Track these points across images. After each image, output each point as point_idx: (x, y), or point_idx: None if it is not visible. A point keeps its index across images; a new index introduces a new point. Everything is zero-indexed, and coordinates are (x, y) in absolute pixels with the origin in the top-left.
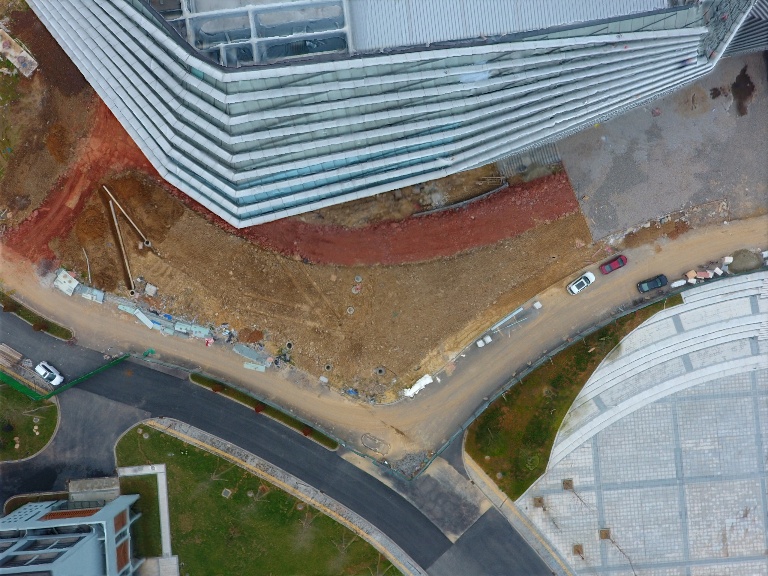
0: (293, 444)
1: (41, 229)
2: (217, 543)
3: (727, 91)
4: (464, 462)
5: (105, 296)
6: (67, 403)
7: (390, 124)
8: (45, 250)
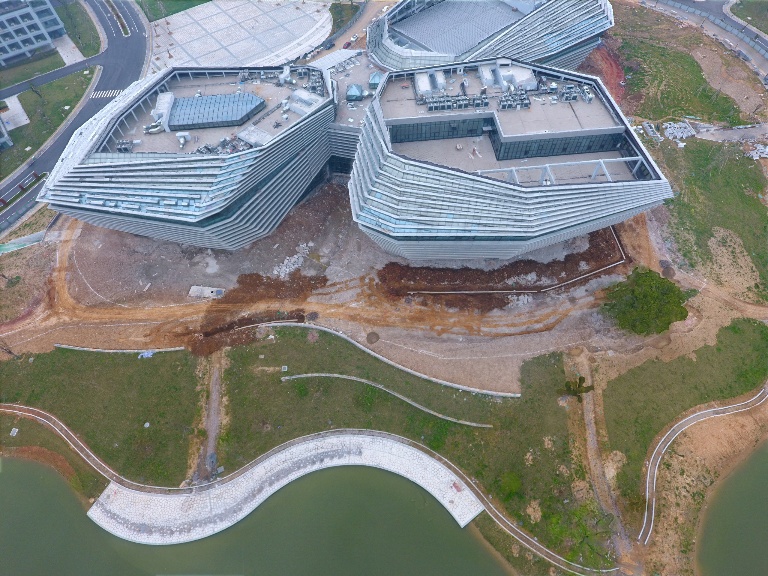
0: None
1: None
2: None
3: None
4: (356, 3)
5: None
6: None
7: None
8: None
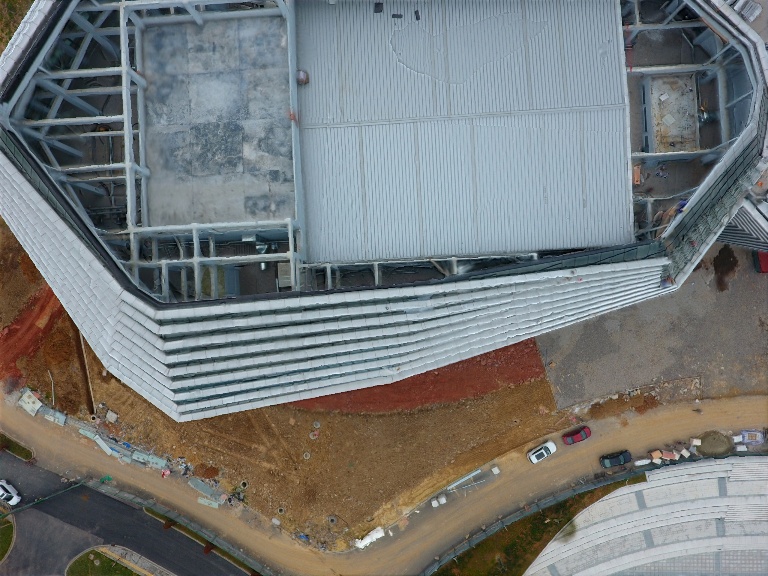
0: None
1: (10, 347)
2: None
3: (709, 264)
4: None
5: (67, 419)
6: (23, 522)
7: (332, 343)
8: (12, 368)
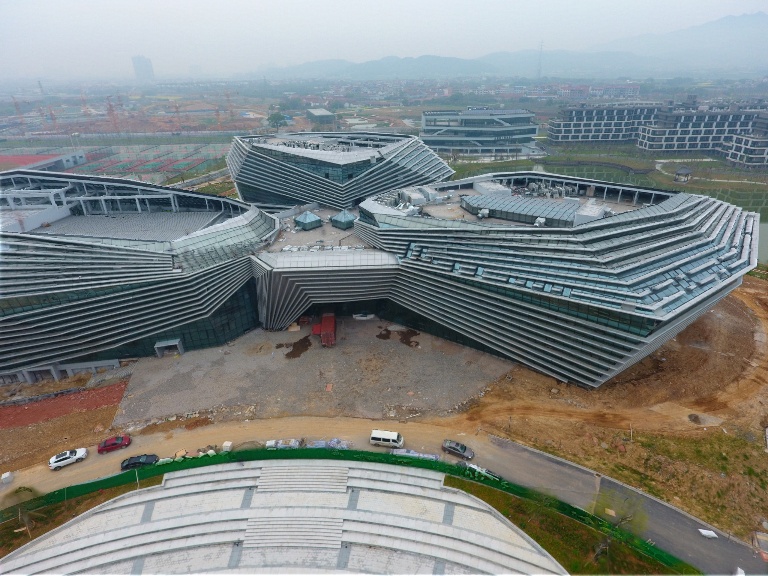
0: None
1: None
2: None
3: (289, 345)
4: None
5: None
6: None
7: None
8: None
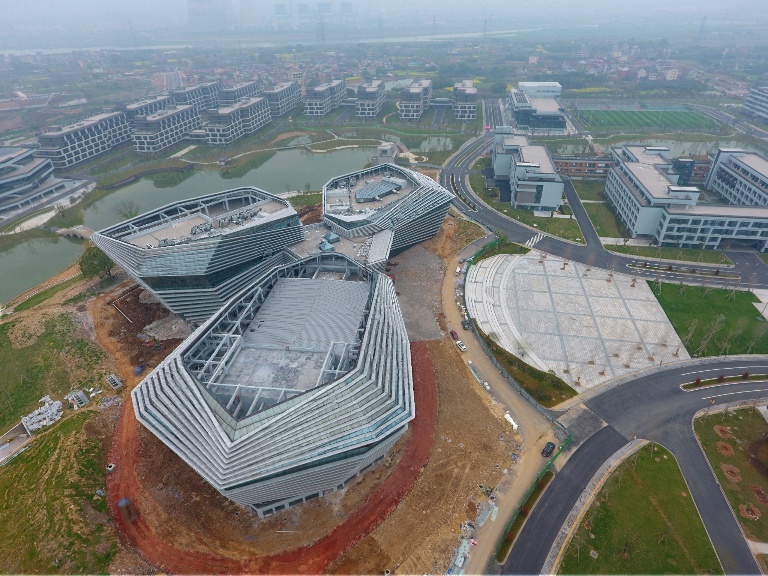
0: (551, 499)
1: None
2: (638, 572)
3: None
4: (557, 410)
5: None
6: None
7: None
8: None
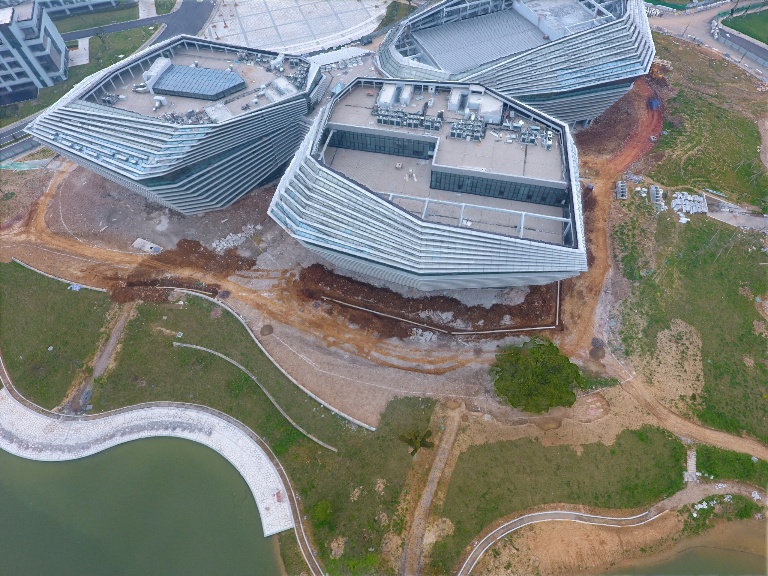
0: None
1: None
2: None
3: None
4: None
5: None
6: None
7: None
8: None
